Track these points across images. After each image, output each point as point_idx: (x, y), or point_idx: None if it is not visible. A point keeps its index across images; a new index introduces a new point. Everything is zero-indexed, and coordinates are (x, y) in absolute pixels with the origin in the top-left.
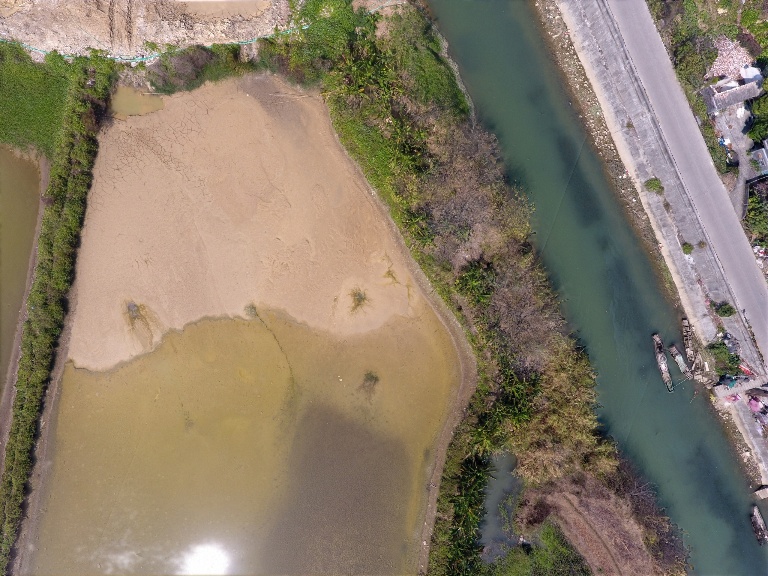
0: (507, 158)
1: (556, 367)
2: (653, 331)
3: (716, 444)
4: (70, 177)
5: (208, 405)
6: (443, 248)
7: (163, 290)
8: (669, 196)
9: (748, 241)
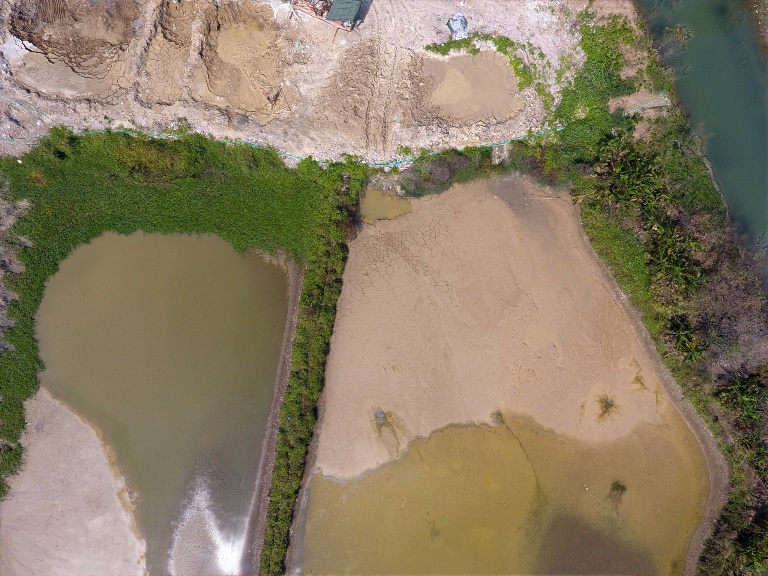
0: None
1: None
2: None
3: None
4: (326, 286)
5: (453, 514)
6: None
7: (410, 397)
8: None
9: None
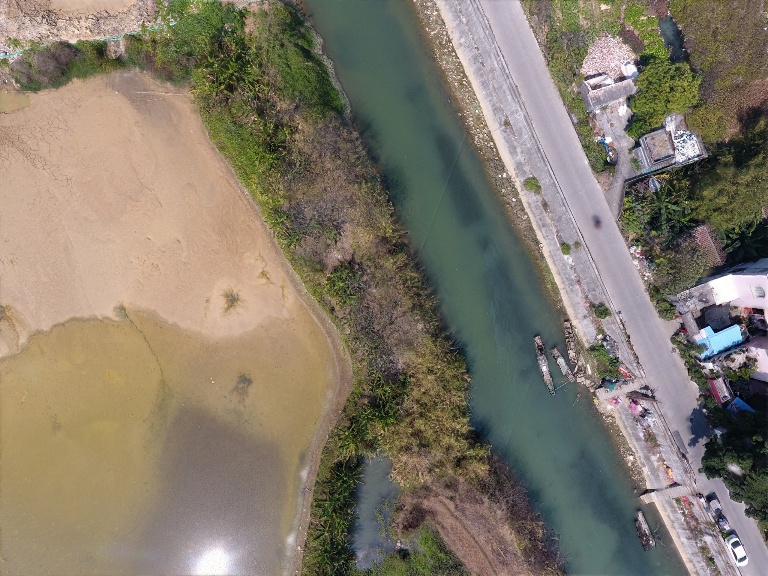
0: (384, 157)
1: (423, 369)
2: (535, 333)
3: (600, 448)
4: None
5: (76, 407)
6: (315, 248)
7: (30, 291)
8: (546, 195)
9: (624, 241)
